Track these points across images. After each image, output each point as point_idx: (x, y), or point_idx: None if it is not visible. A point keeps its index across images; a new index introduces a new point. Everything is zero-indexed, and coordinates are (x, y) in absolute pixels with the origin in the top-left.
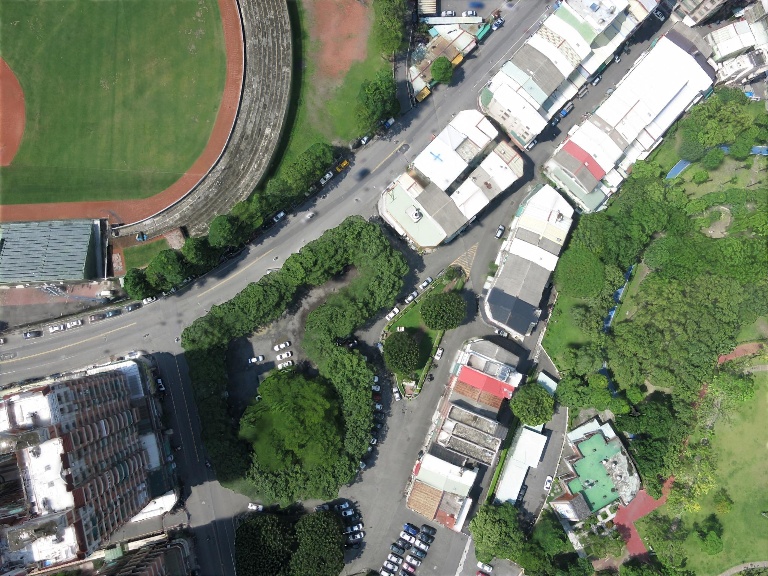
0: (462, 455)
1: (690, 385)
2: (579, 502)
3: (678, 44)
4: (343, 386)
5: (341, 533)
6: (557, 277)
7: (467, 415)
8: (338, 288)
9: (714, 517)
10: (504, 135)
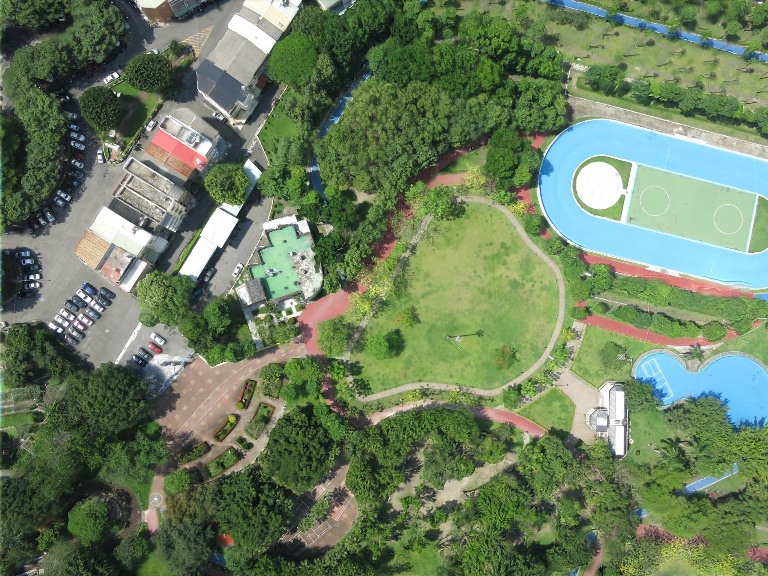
0: (131, 207)
1: (385, 189)
2: (255, 285)
3: None
4: (29, 124)
5: (4, 270)
6: (270, 59)
7: (146, 171)
8: None
9: (399, 332)
10: None
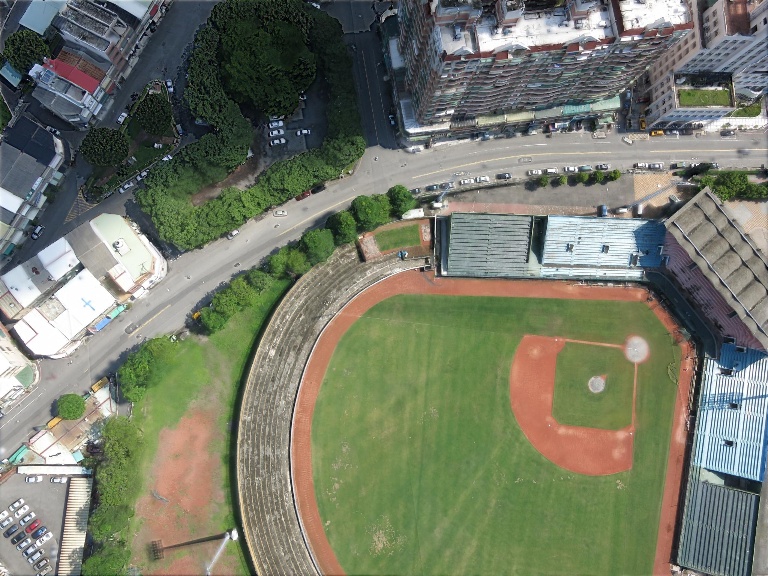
0: (101, 6)
1: None
2: None
3: None
4: (214, 87)
5: None
6: None
7: (92, 43)
8: (218, 192)
9: None
10: (16, 337)
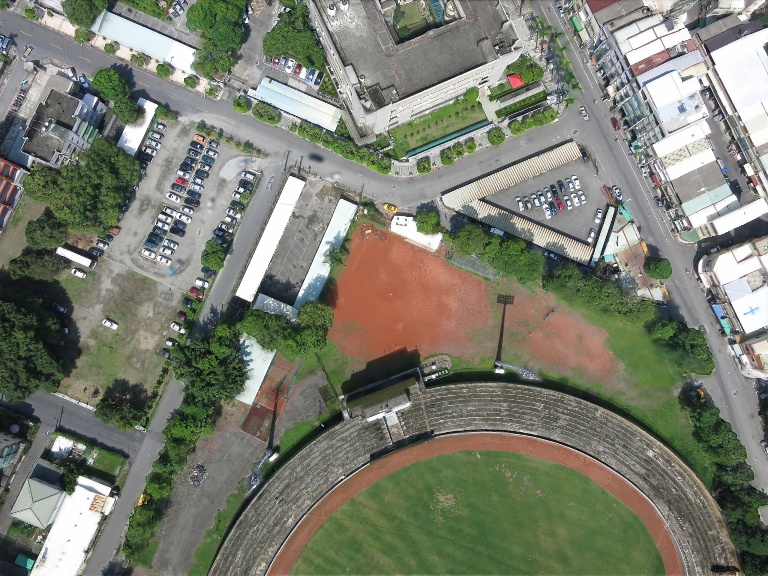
0: None
1: None
2: None
3: (724, 44)
4: None
5: None
6: None
7: None
8: None
9: None
10: None
